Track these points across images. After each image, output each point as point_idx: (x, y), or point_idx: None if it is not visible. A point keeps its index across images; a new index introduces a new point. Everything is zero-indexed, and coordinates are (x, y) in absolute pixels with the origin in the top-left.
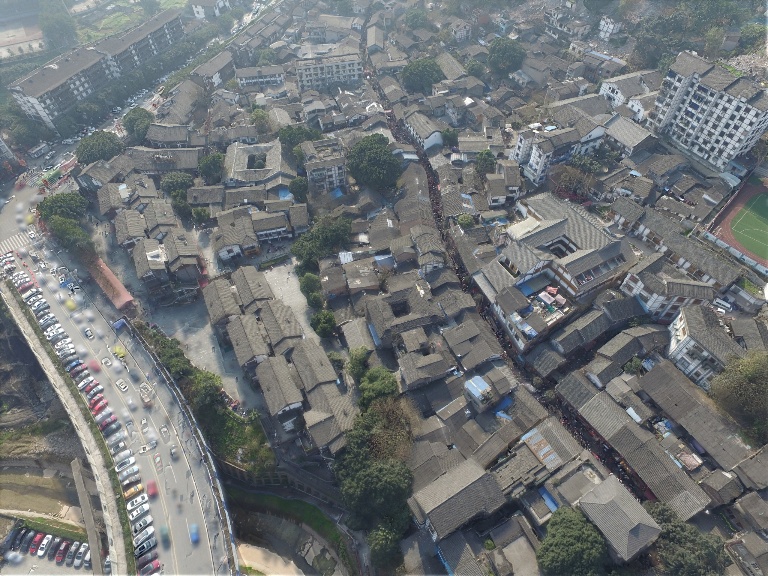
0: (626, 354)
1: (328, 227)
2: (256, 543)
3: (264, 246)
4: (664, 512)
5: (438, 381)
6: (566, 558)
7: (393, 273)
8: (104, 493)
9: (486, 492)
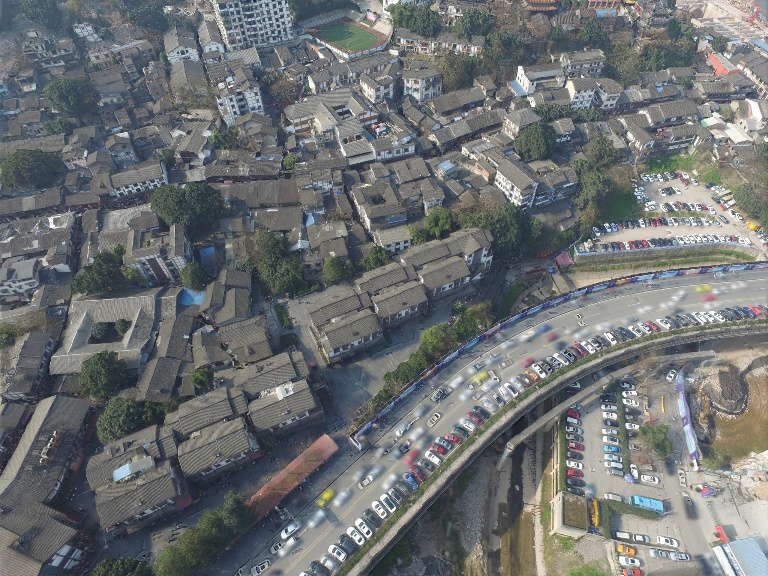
0: None
1: None
2: None
3: None
4: None
5: None
6: None
7: (329, 215)
8: None
9: None
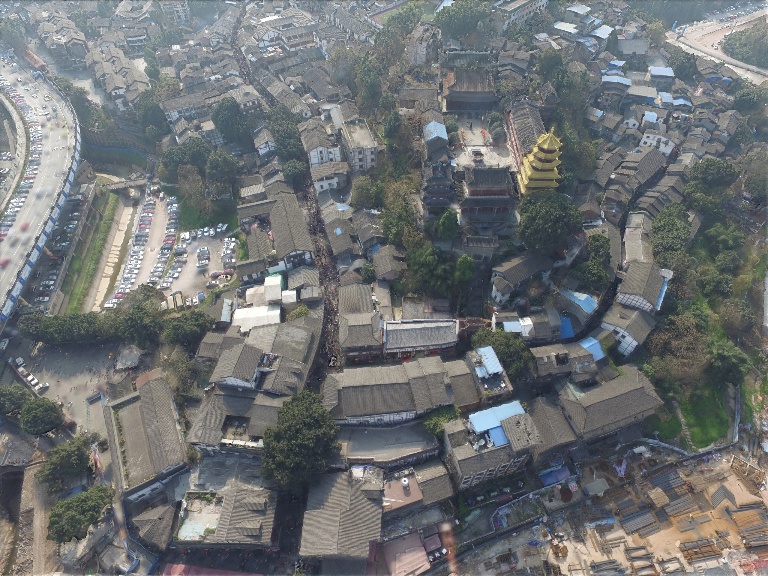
0: (302, 69)
1: (167, 32)
2: (106, 173)
3: (133, 51)
4: (277, 105)
5: (201, 83)
6: (217, 108)
7: None
8: (19, 125)
9: (196, 99)
